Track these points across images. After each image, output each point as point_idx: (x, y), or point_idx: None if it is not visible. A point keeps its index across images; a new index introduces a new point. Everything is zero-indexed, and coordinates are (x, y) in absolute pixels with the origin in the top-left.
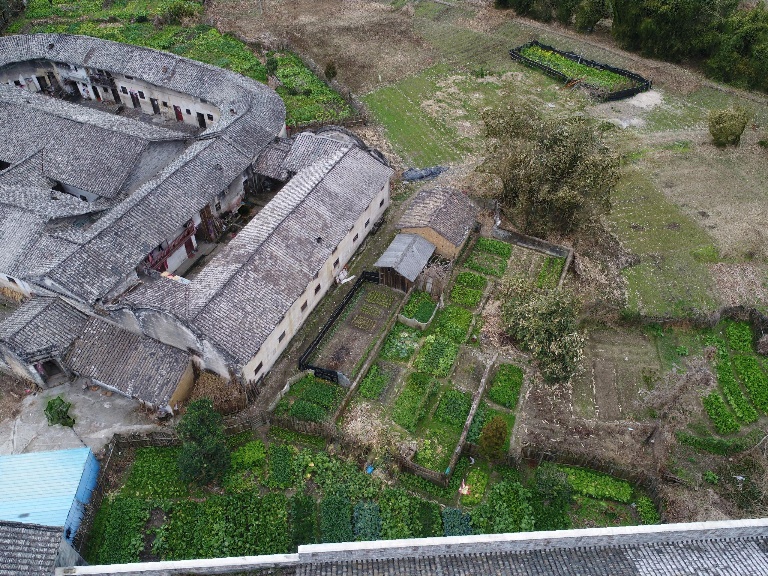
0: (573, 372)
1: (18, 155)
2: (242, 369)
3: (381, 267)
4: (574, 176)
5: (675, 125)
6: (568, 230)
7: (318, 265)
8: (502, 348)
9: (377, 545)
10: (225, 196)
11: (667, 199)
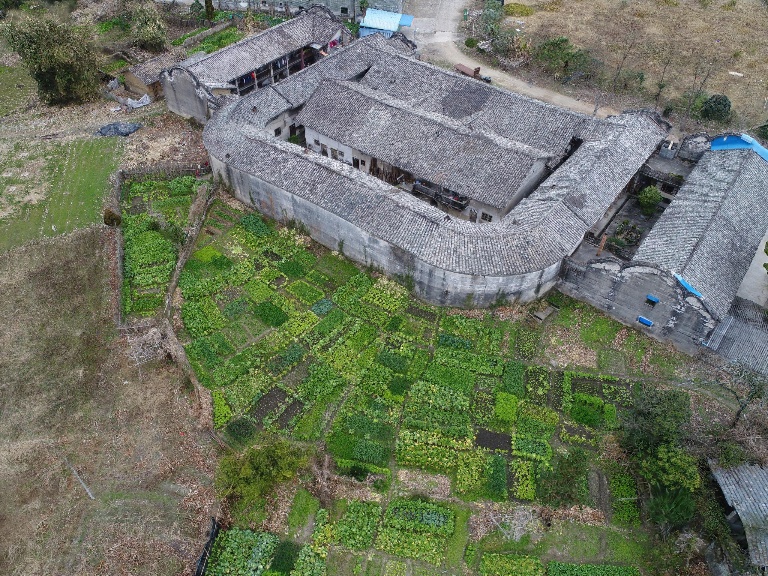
0: None
1: None
2: None
3: None
4: None
5: None
6: None
7: None
8: (171, 51)
9: None
10: None
11: None
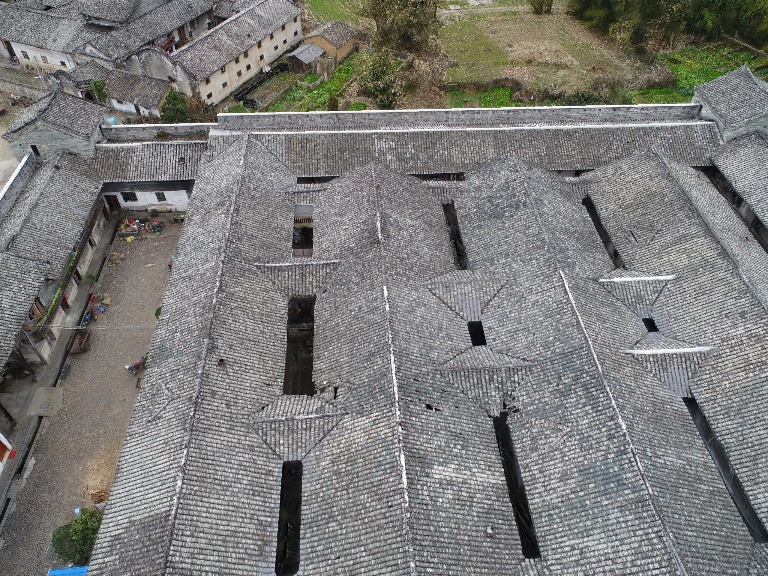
0: (394, 102)
1: (62, 2)
2: (199, 87)
3: (289, 58)
4: (410, 5)
5: (513, 4)
6: (415, 49)
7: (247, 47)
8: (358, 98)
9: (255, 113)
10: (195, 28)
11: (490, 39)
